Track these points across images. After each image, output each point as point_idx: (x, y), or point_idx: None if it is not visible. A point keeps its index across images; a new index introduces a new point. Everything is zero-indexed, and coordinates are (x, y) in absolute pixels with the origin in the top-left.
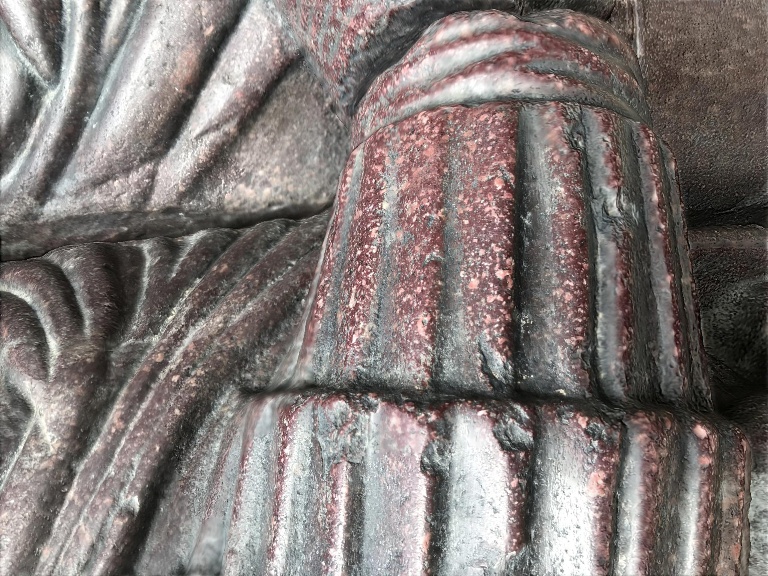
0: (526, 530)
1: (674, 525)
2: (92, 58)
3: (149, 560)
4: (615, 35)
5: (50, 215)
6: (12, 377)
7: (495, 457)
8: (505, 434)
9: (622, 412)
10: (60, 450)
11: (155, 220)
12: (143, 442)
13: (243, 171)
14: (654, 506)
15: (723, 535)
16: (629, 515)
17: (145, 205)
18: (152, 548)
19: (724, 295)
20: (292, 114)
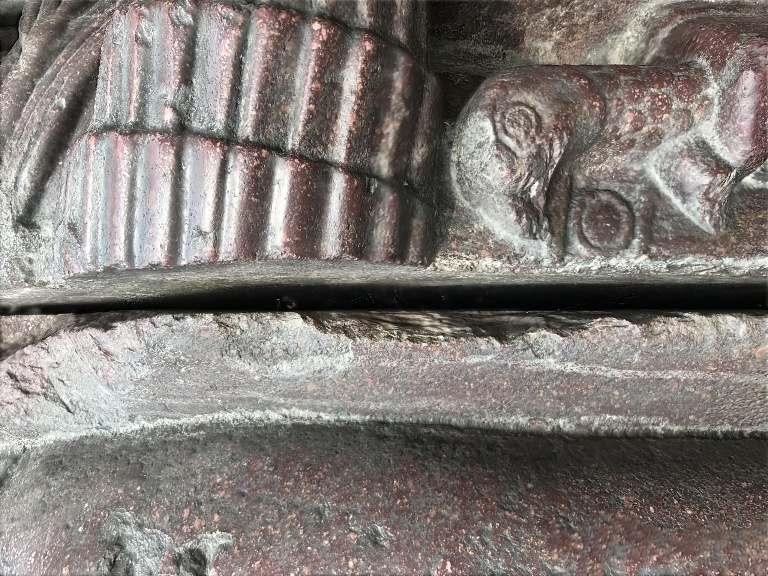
0: (186, 76)
1: (289, 86)
2: None
3: (75, 139)
4: None
5: None
6: None
7: (168, 29)
8: (176, 15)
9: (250, 4)
10: (26, 69)
11: None
12: (71, 69)
13: None
14: (263, 65)
15: (343, 106)
16: (249, 71)
17: None
18: (78, 133)
19: (637, 17)
20: None
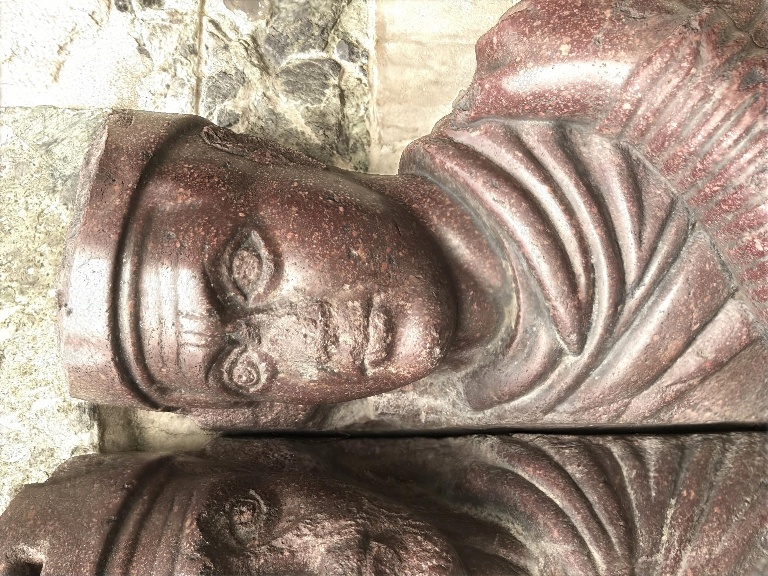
0: None
1: None
2: (606, 341)
3: None
4: None
5: (547, 420)
6: (570, 572)
7: None
8: None
9: None
10: None
11: (616, 424)
12: None
13: (693, 402)
14: None
15: None
16: None
17: (615, 420)
18: None
19: None
20: (742, 369)
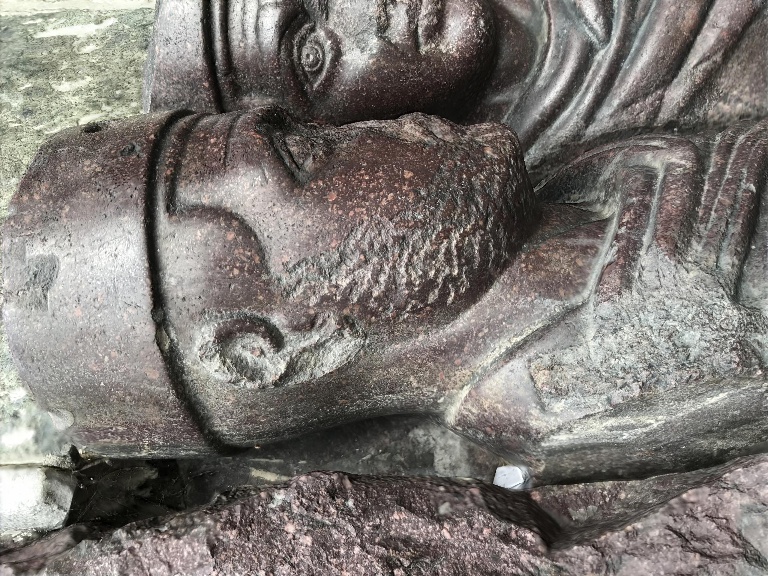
0: None
1: None
2: (630, 25)
3: (766, 224)
4: None
5: (589, 135)
6: (631, 163)
7: None
8: None
9: None
10: (693, 166)
11: None
12: (744, 163)
13: (722, 92)
14: None
15: None
16: None
17: (653, 122)
18: (765, 220)
19: None
20: (758, 48)
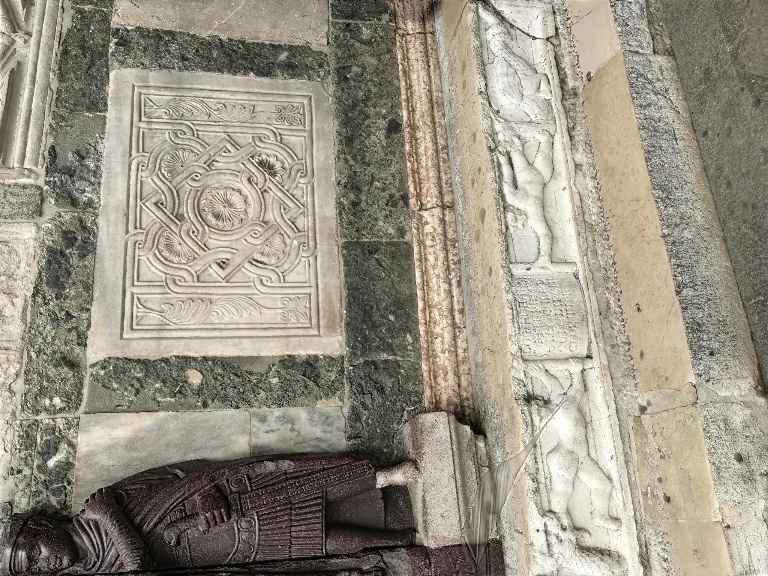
0: None
1: None
2: None
3: None
4: None
5: None
6: None
7: None
8: None
9: None
10: None
11: None
12: None
13: (123, 568)
14: None
15: None
16: None
17: None
18: None
19: None
20: None
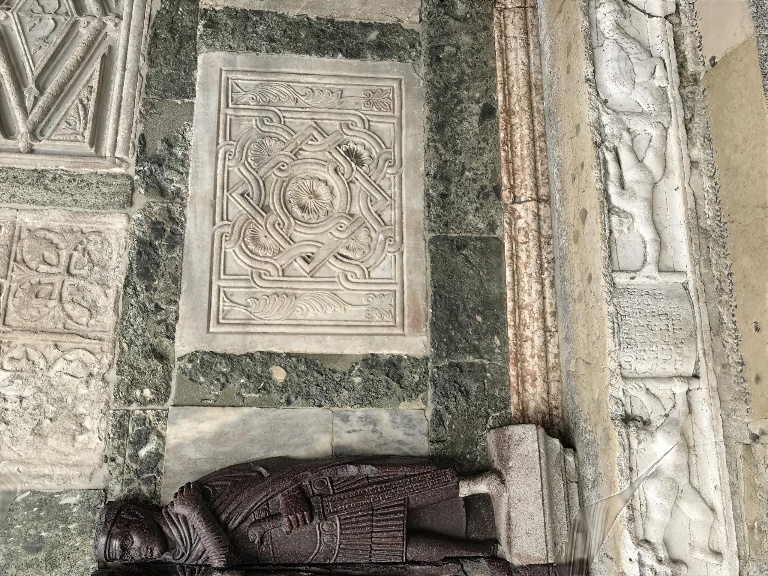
0: None
1: None
2: None
3: None
4: (233, 574)
5: (186, 563)
6: None
7: None
8: None
9: None
10: None
11: None
12: None
13: (209, 561)
14: None
15: None
16: None
17: None
18: None
19: None
20: None
